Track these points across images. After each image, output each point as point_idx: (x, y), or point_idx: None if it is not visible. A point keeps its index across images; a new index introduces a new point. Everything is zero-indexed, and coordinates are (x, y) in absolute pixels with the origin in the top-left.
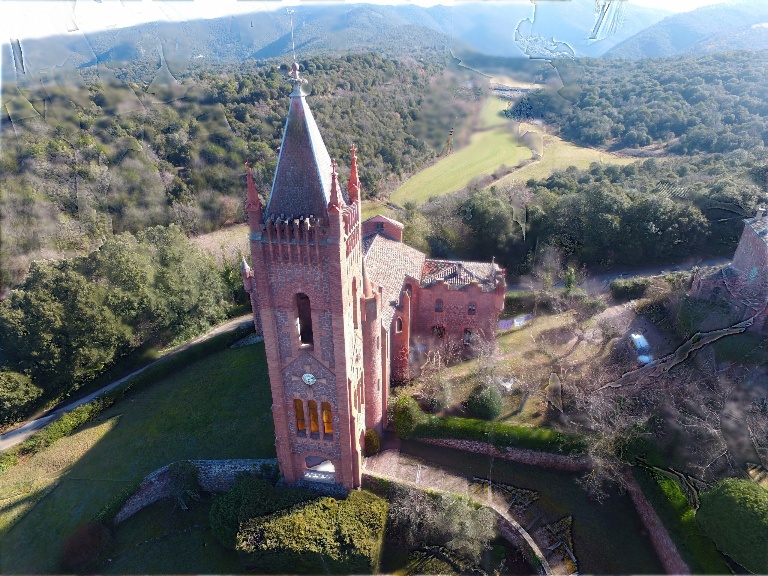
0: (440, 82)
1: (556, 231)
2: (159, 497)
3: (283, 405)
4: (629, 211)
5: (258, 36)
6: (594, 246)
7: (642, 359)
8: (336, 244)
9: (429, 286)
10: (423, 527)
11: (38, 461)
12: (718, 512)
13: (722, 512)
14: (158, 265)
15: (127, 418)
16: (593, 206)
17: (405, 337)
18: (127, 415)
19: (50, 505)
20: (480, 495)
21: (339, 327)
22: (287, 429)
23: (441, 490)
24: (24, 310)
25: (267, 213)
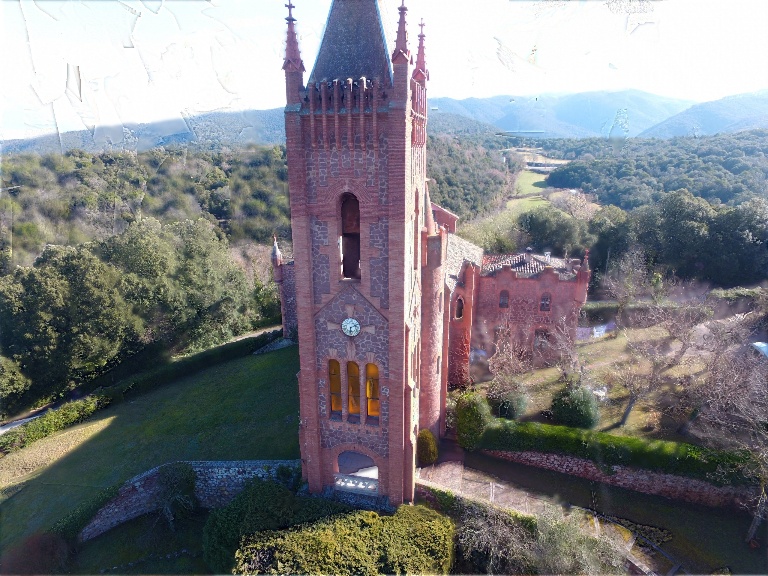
0: (517, 1)
1: (628, 246)
2: (142, 511)
3: (313, 368)
4: (717, 220)
5: (306, 59)
6: (677, 259)
7: None
8: (401, 109)
9: (492, 274)
10: (508, 564)
11: (7, 463)
12: None
13: None
14: (181, 256)
15: (122, 419)
16: (671, 216)
17: (467, 324)
18: (123, 416)
19: (5, 513)
20: (584, 528)
21: (398, 240)
22: (316, 406)
23: (529, 514)
24: (26, 288)
25: None
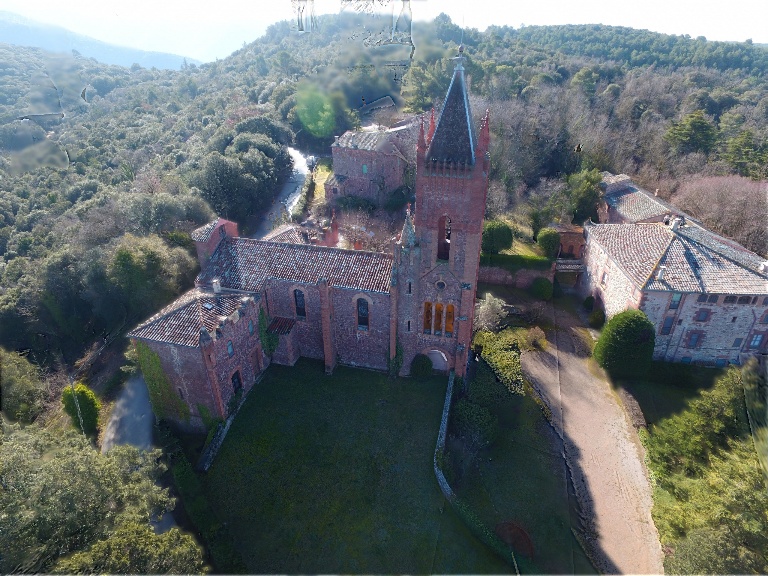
0: (338, 63)
1: None
2: None
3: None
4: (244, 169)
5: None
6: (249, 202)
7: (371, 235)
8: None
9: None
10: None
11: None
12: (498, 236)
13: (498, 235)
14: None
15: None
16: (223, 173)
17: None
18: None
19: None
20: None
21: None
22: None
23: None
24: None
25: None
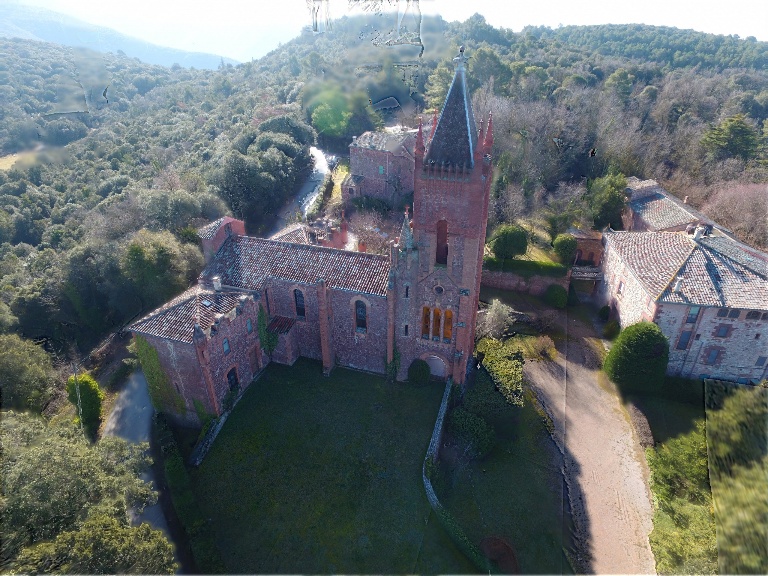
0: (345, 63)
1: None
2: None
3: None
4: (263, 168)
5: None
6: (265, 200)
7: (385, 236)
8: None
9: None
10: None
11: None
12: (511, 241)
13: (512, 240)
14: None
15: None
16: (242, 172)
17: None
18: None
19: None
20: None
21: None
22: None
23: None
24: None
25: (473, 161)
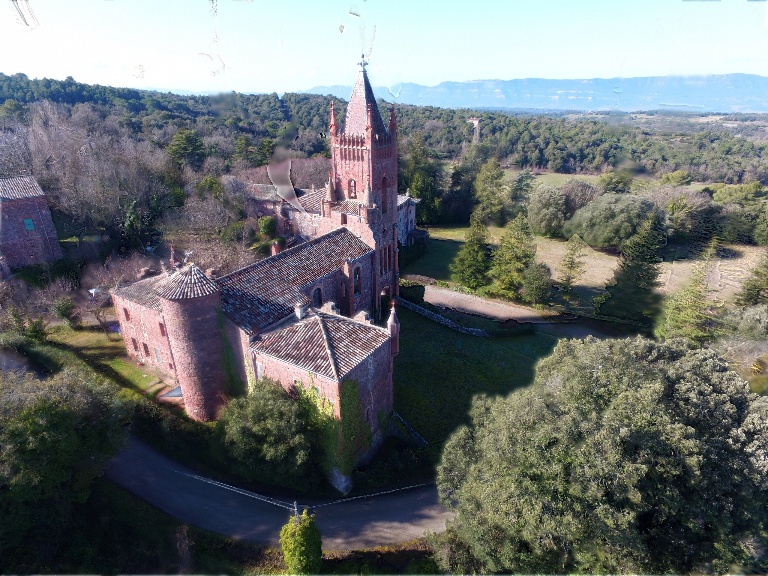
0: None
1: None
2: None
3: None
4: None
5: None
6: None
7: None
8: None
9: None
10: None
11: None
12: None
13: None
14: None
15: None
16: None
17: None
18: None
19: None
20: None
21: None
22: None
23: None
24: None
25: (387, 132)
